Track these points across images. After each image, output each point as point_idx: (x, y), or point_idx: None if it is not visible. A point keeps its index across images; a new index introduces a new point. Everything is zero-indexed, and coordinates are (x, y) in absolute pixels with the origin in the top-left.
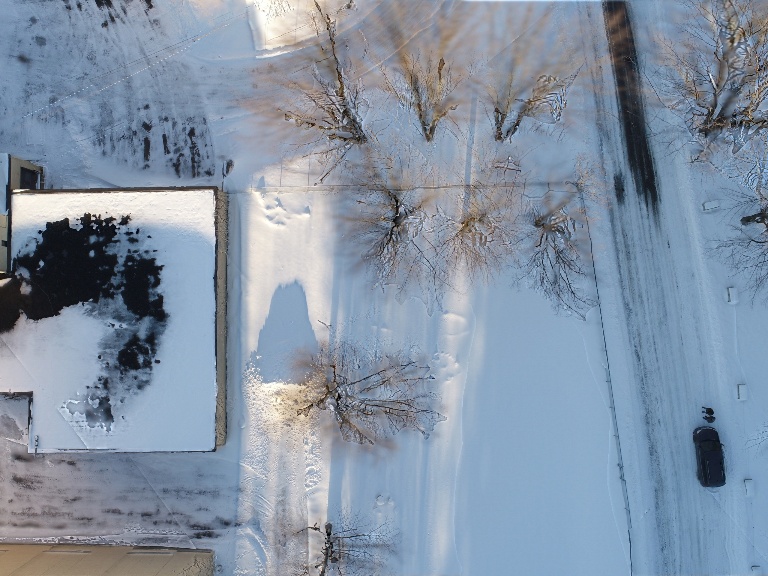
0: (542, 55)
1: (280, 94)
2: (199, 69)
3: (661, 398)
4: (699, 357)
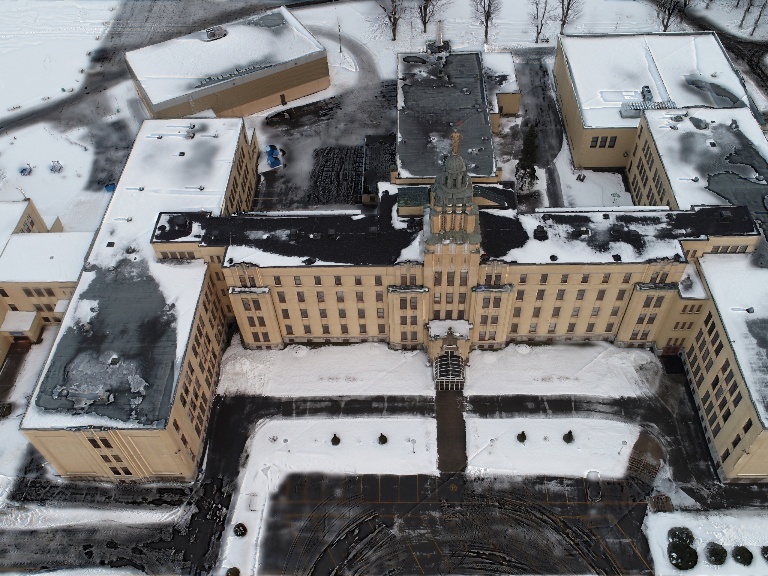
0: (366, 7)
1: (373, 66)
2: None
3: None
4: None
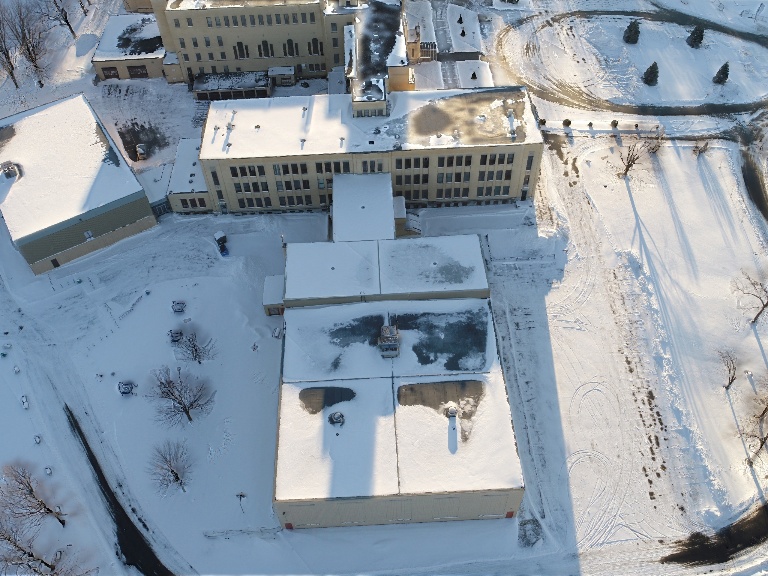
0: None
1: None
2: None
3: None
4: None
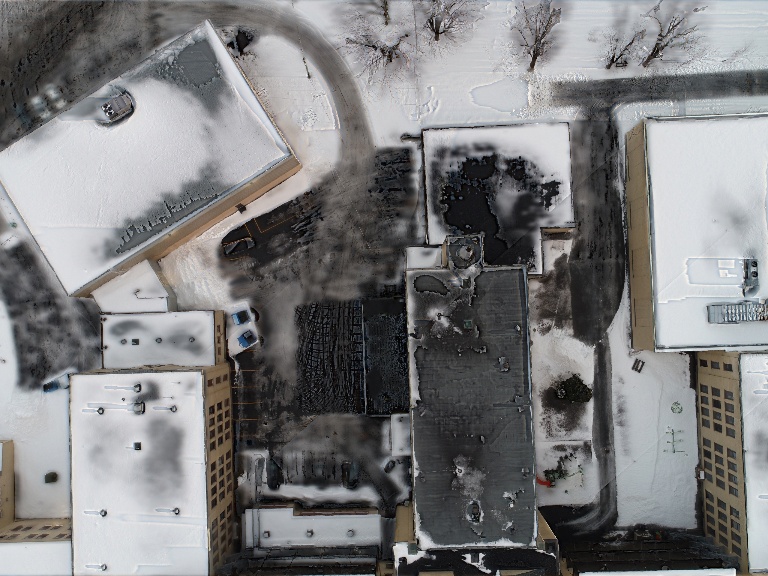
0: None
1: (361, 114)
2: (347, 162)
3: None
4: None
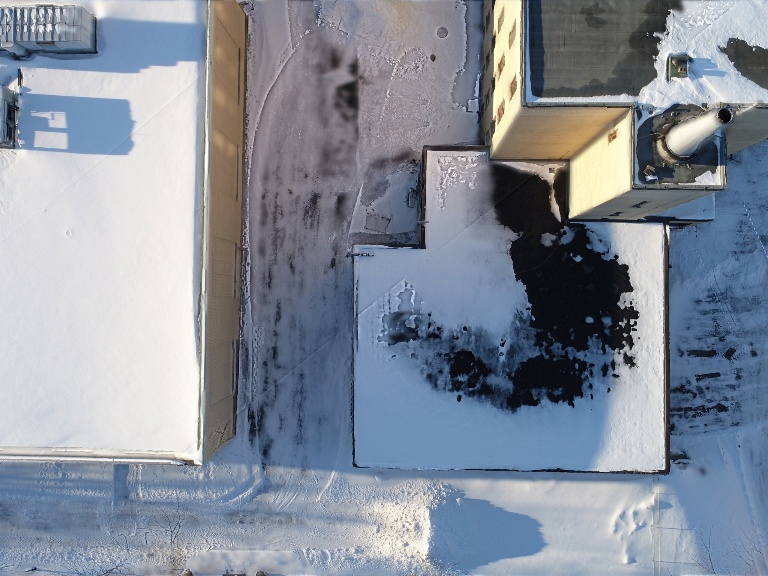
0: None
1: (767, 515)
2: None
3: None
4: None
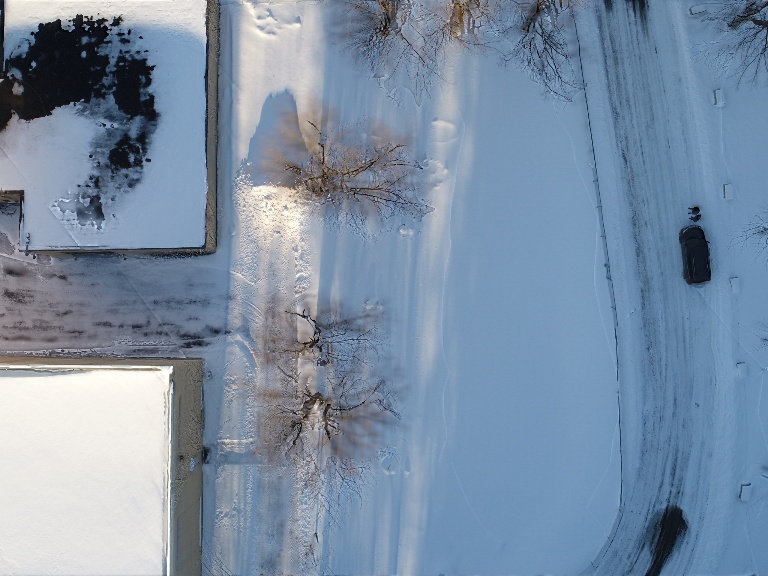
0: None
1: None
2: None
3: (648, 200)
4: (685, 159)
